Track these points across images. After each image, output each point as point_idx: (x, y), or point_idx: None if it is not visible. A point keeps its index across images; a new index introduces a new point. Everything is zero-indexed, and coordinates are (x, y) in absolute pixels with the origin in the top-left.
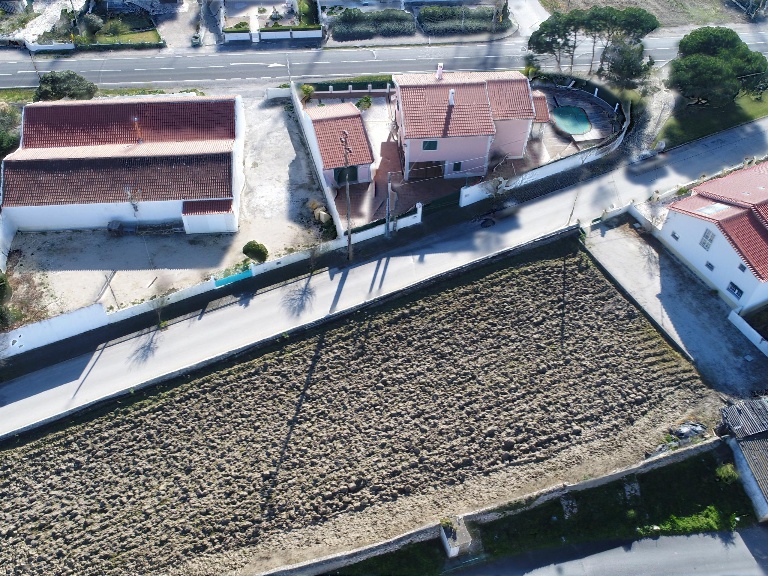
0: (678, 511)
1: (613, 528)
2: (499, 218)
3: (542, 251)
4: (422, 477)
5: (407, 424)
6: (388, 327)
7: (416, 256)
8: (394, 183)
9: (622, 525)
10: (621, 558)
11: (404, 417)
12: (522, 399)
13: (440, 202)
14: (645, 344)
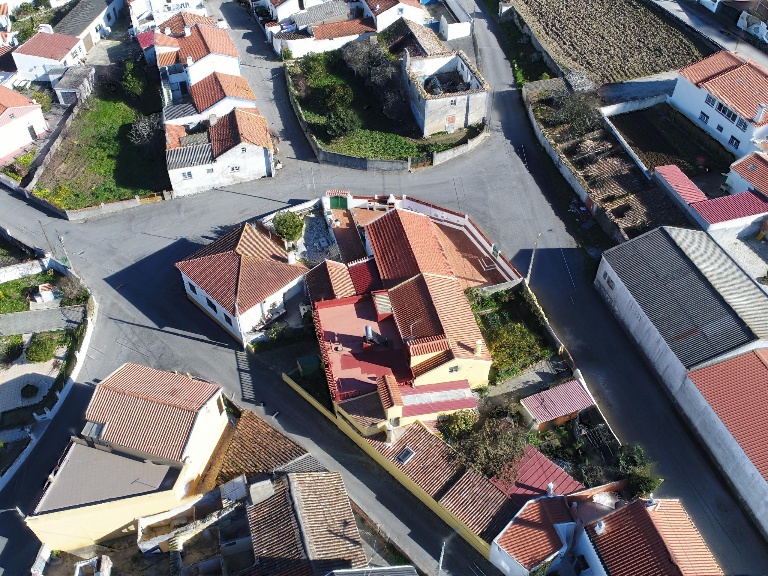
0: (525, 72)
1: (515, 54)
2: (732, 37)
3: (705, 48)
4: (535, 6)
5: (562, 3)
6: (623, 0)
7: (682, 10)
8: (751, 6)
9: (517, 56)
10: (501, 56)
11: (566, 2)
12: (583, 31)
13: (731, 10)
14: (634, 72)
